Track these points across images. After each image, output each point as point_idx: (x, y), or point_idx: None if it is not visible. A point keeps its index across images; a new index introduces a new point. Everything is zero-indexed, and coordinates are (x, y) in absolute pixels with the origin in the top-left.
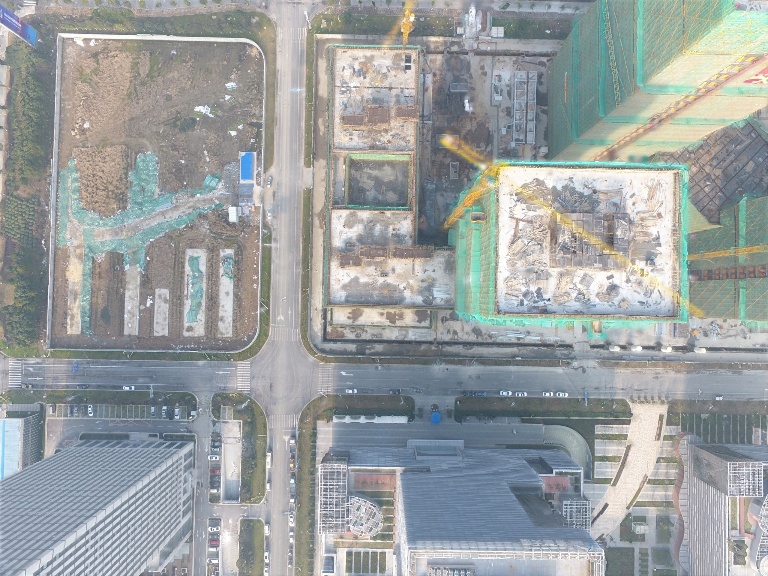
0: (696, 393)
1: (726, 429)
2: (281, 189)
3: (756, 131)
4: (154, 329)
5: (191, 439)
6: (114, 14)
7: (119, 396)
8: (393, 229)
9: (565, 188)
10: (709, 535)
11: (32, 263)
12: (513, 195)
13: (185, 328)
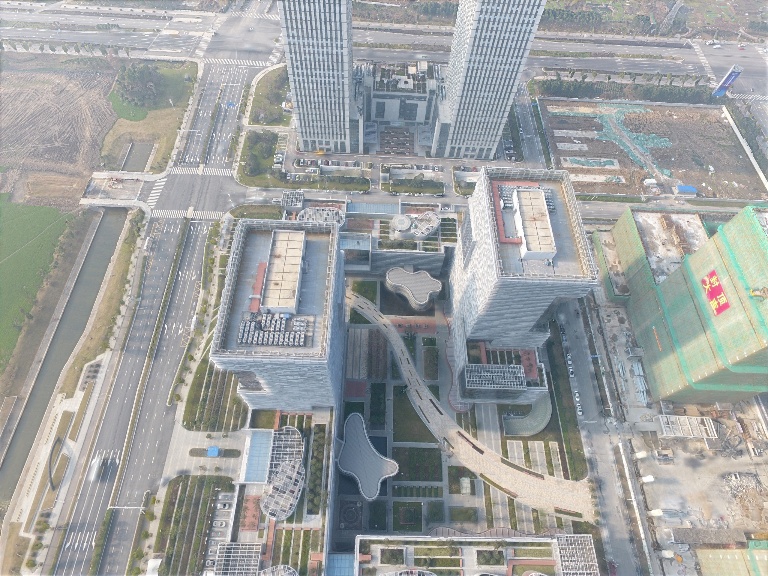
0: None
1: None
2: None
3: None
4: (561, 143)
5: (494, 158)
6: (752, 127)
7: (515, 126)
8: None
9: None
10: None
11: (585, 92)
12: None
13: (565, 158)
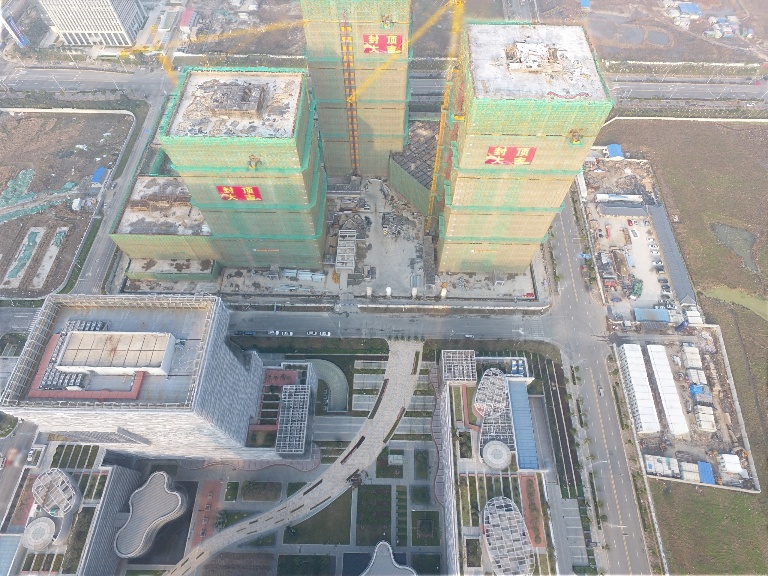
0: (449, 334)
1: None
2: (121, 190)
3: None
4: None
5: None
6: (40, 97)
7: None
8: (181, 189)
9: (231, 83)
10: (445, 440)
11: None
12: (197, 86)
13: (3, 282)
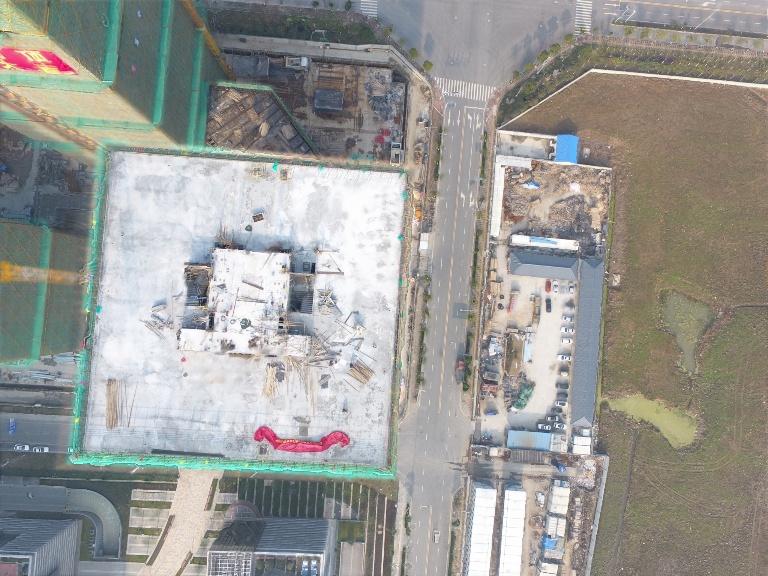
0: None
1: (292, 498)
2: None
3: (307, 144)
4: None
5: None
6: None
7: None
8: None
9: None
10: None
11: None
12: None
13: None
